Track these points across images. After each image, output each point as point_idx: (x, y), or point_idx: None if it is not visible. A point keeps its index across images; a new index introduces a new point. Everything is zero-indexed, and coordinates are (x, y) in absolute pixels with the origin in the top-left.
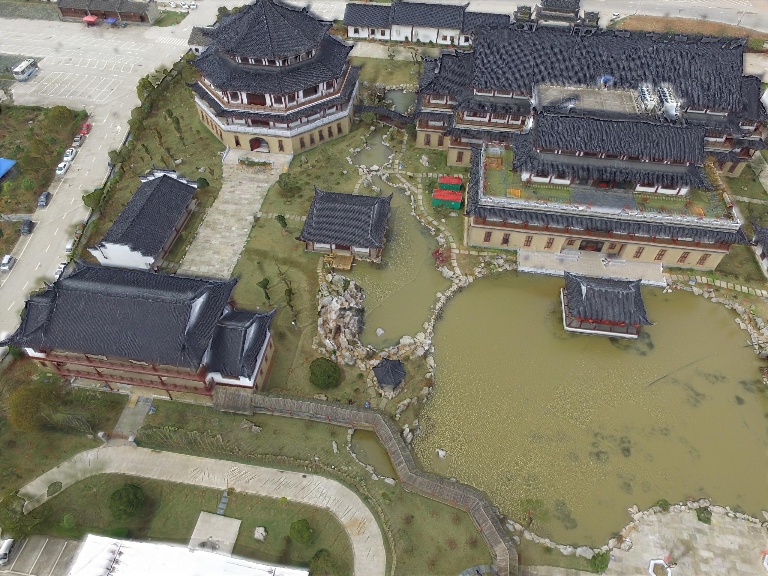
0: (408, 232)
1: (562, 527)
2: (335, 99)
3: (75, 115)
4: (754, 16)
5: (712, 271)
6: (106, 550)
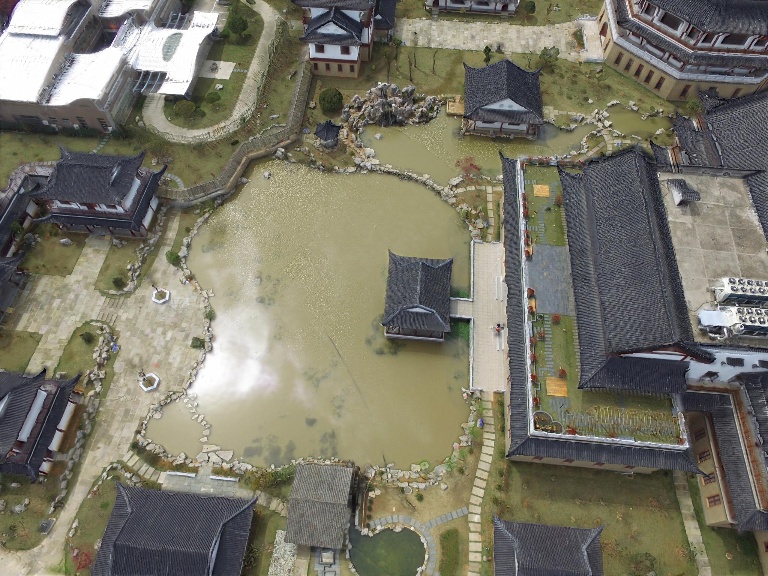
0: (511, 155)
1: (204, 243)
2: (684, 51)
3: None
4: None
5: (504, 454)
6: (210, 22)
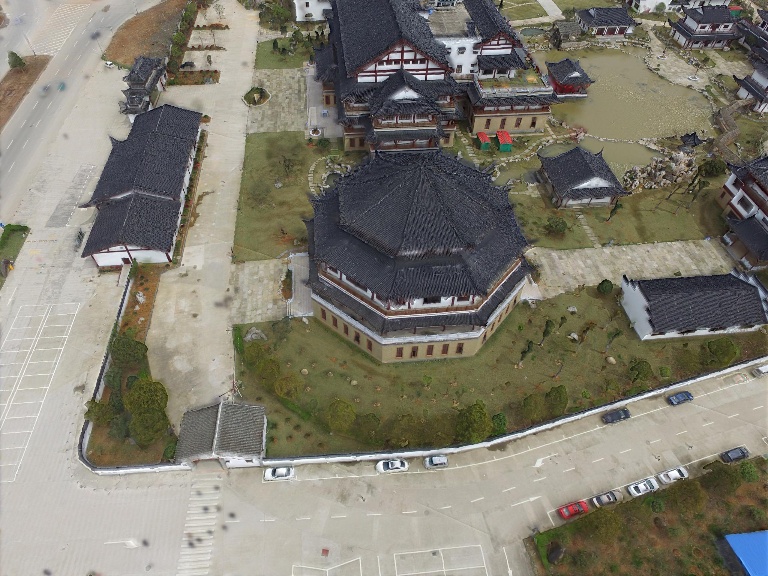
0: None
1: (700, 100)
2: None
3: (556, 551)
4: (115, 6)
5: None
6: None
